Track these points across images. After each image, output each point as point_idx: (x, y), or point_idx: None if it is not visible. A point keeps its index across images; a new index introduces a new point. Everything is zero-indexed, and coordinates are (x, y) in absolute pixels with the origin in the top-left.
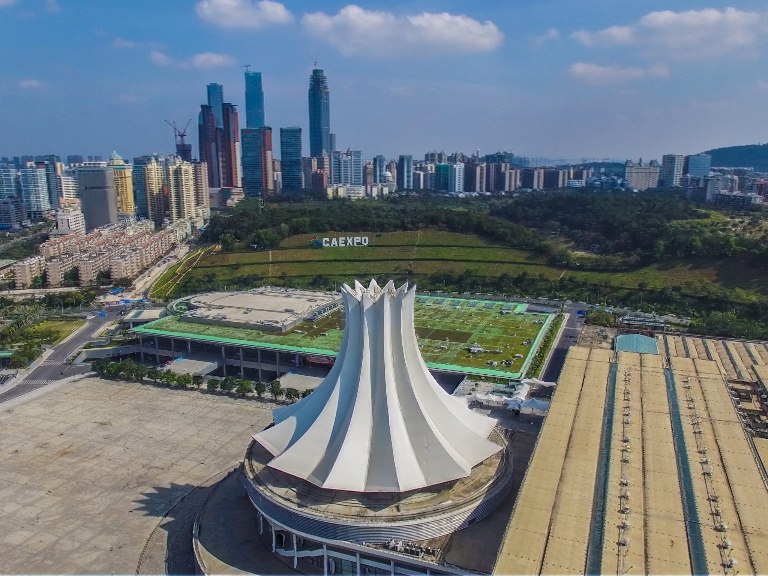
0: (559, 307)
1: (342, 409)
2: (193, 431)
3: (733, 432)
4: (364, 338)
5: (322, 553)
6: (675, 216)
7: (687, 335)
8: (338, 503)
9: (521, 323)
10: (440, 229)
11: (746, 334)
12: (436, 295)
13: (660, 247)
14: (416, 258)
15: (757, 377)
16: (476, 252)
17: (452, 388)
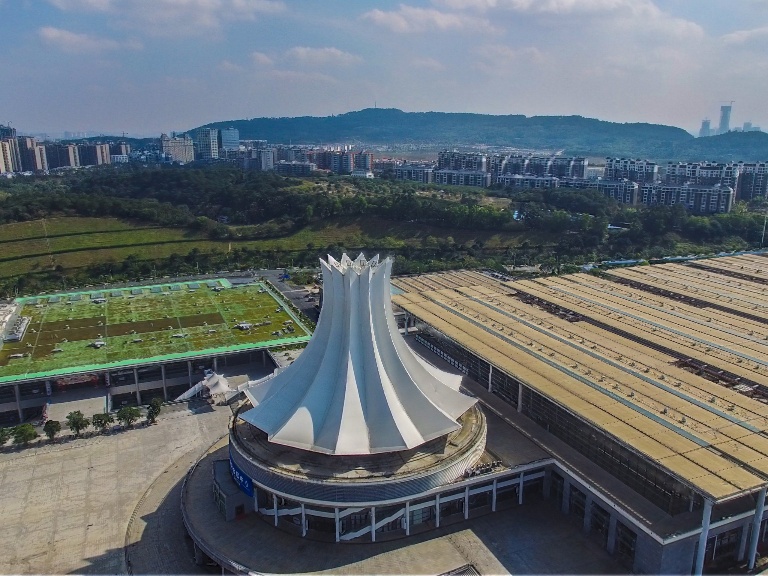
0: (252, 276)
1: (360, 382)
2: (17, 503)
3: (563, 323)
4: (369, 309)
5: (403, 513)
6: (279, 184)
7: (397, 277)
8: (410, 461)
9: (248, 295)
10: (68, 215)
11: (419, 270)
12: (111, 287)
13: (310, 211)
14: (54, 251)
15: (515, 289)
16: (125, 236)
17: (247, 367)
